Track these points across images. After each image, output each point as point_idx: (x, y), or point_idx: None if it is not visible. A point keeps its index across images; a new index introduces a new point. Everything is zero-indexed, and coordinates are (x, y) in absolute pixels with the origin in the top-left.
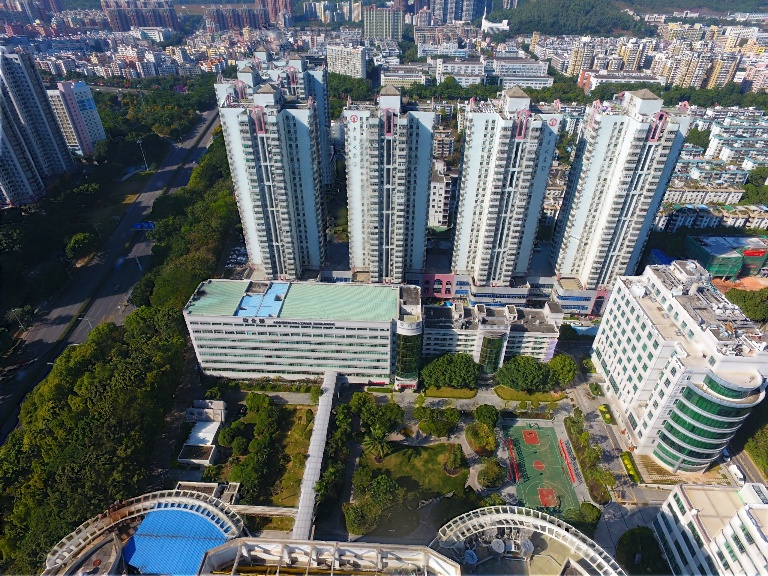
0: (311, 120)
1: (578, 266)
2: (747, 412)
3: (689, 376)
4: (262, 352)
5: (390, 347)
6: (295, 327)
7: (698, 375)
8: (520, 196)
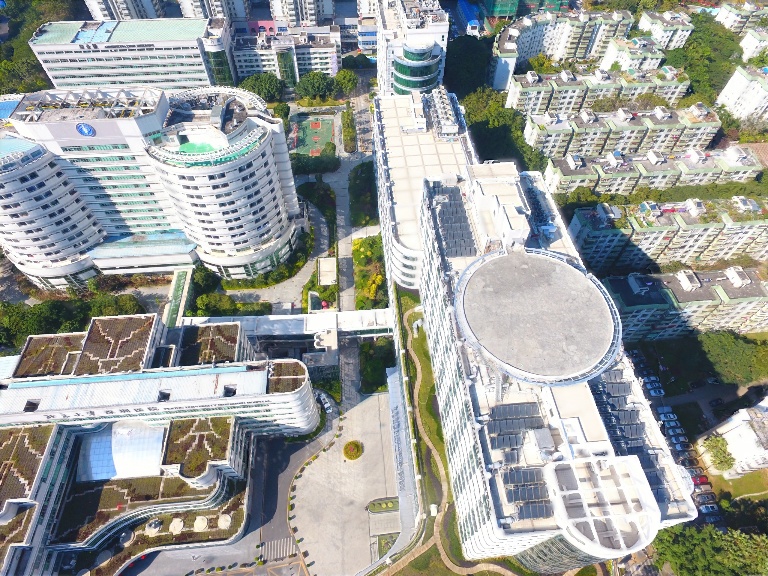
0: None
1: (373, 5)
2: (431, 73)
3: (393, 50)
4: (106, 79)
5: (204, 65)
6: (124, 51)
7: (398, 48)
8: None
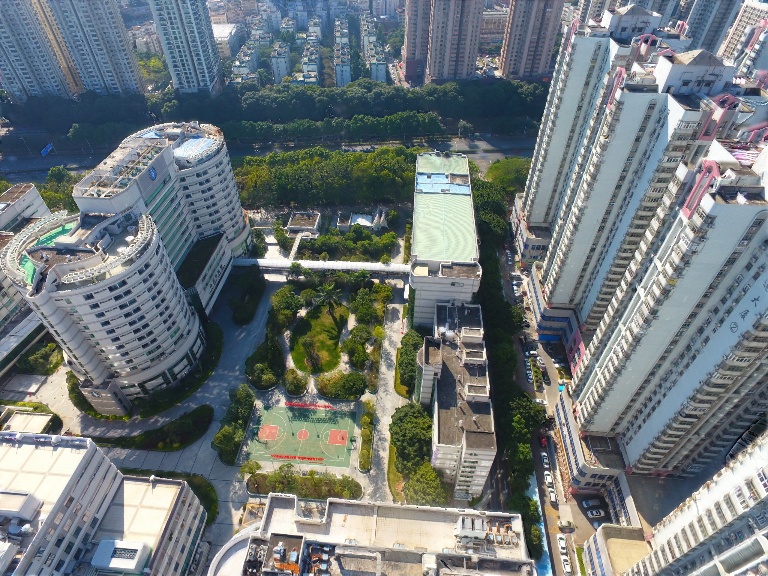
0: (616, 61)
1: None
2: None
3: None
4: None
5: None
6: None
7: None
8: (639, 313)
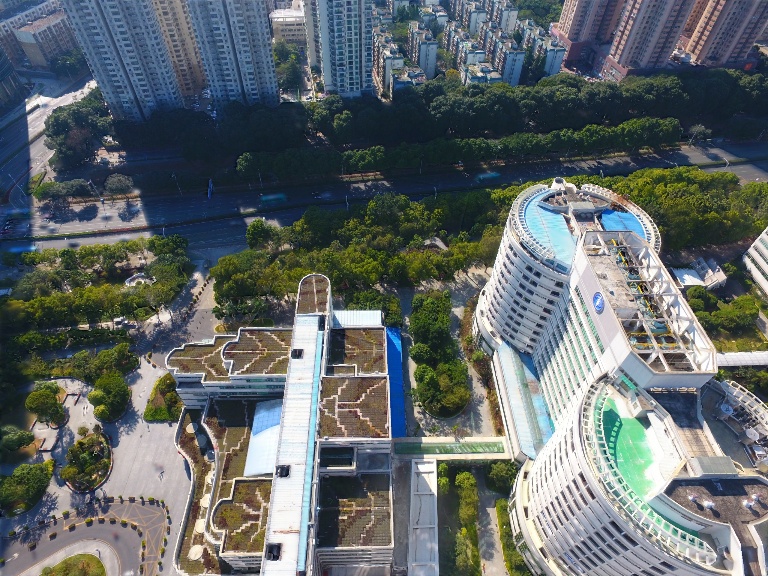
0: None
1: None
2: None
3: None
4: None
5: None
6: None
7: None
8: None
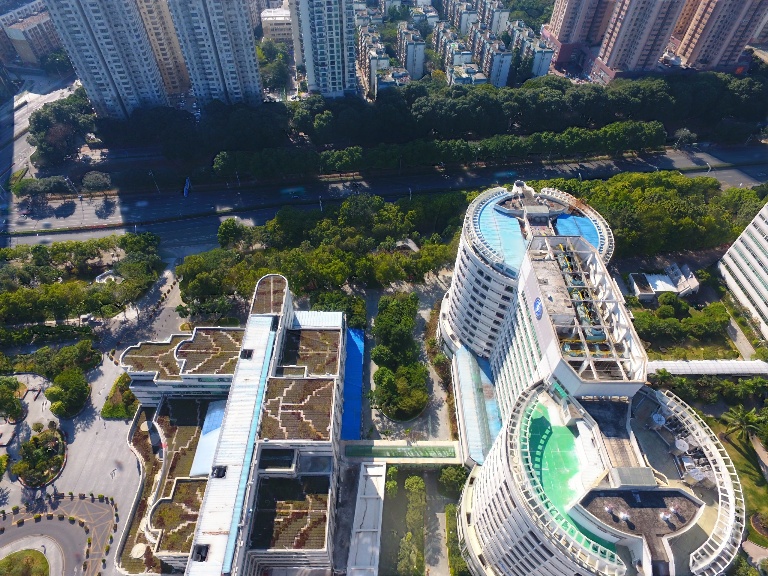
0: None
1: None
2: None
3: None
4: None
5: None
6: None
7: None
8: None
